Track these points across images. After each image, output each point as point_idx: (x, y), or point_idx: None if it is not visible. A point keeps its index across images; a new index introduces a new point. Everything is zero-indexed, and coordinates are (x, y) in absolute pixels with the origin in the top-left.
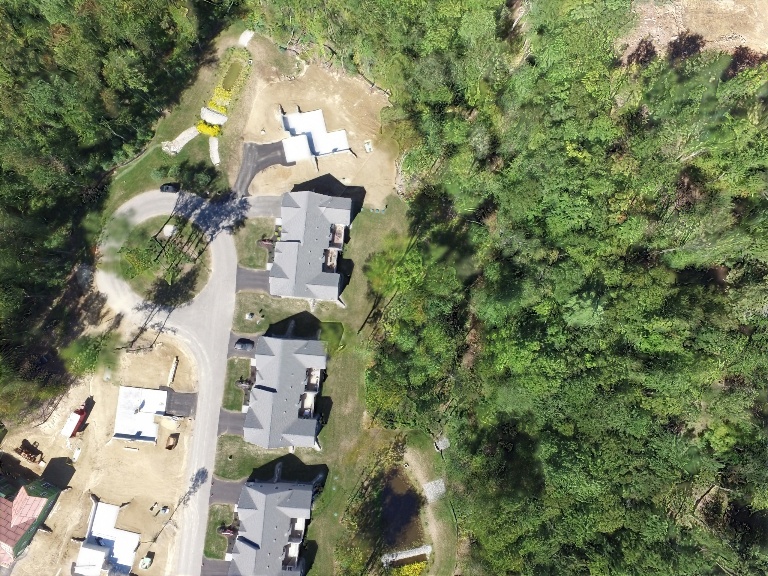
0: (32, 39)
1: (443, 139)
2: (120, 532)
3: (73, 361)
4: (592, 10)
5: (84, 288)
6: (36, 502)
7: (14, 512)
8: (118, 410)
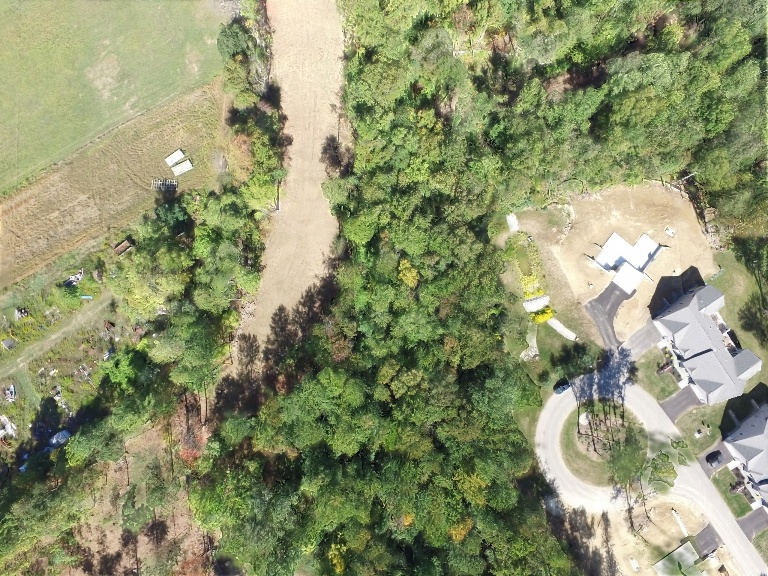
0: (434, 366)
1: None
2: None
3: None
4: None
5: (561, 515)
6: None
7: None
8: None
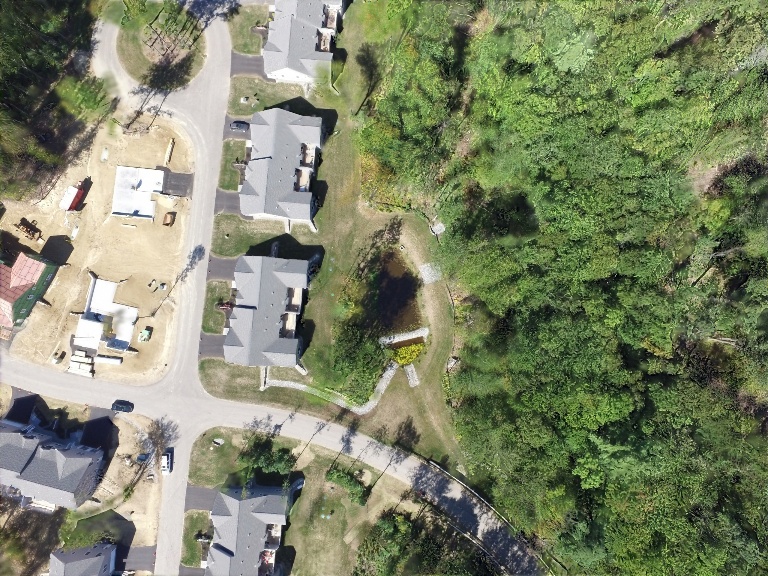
0: None
1: None
2: (118, 308)
3: (70, 142)
4: None
5: (81, 73)
6: (35, 265)
7: (13, 275)
8: (115, 189)
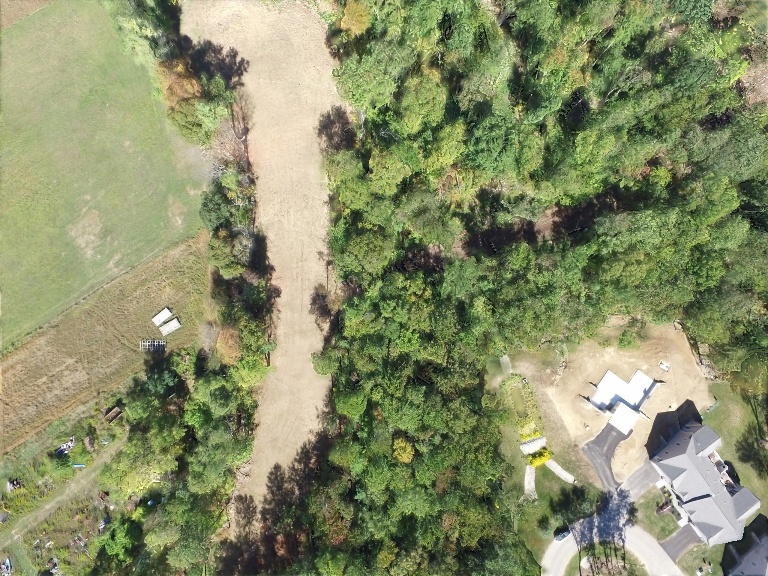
0: (433, 546)
1: None
2: None
3: None
4: None
5: None
6: None
7: None
8: None
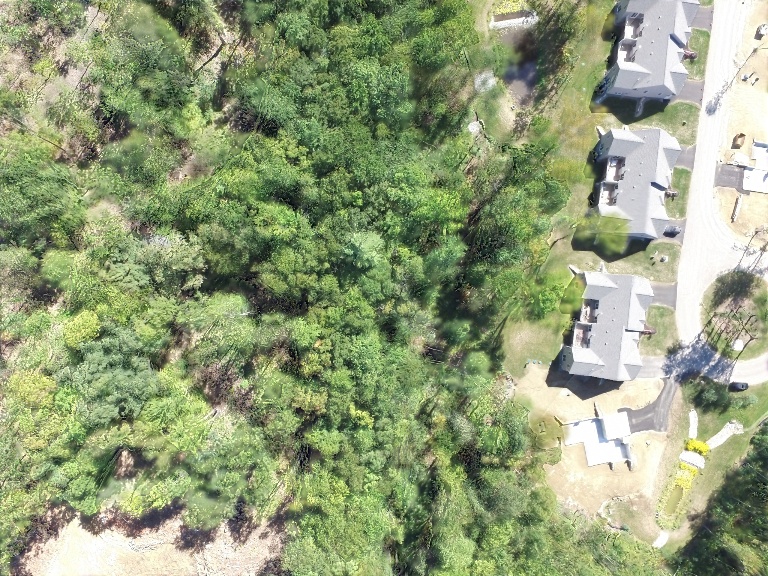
0: None
1: (463, 436)
2: None
3: None
4: (337, 570)
5: None
6: None
7: None
8: None
